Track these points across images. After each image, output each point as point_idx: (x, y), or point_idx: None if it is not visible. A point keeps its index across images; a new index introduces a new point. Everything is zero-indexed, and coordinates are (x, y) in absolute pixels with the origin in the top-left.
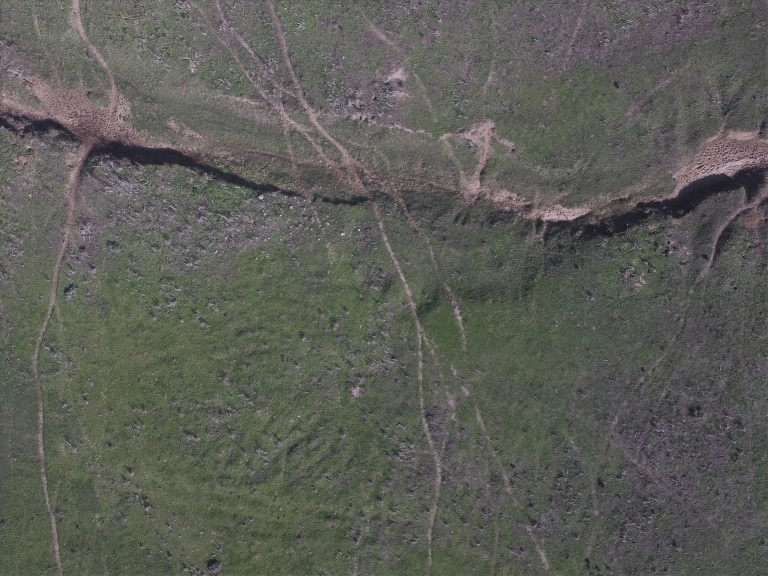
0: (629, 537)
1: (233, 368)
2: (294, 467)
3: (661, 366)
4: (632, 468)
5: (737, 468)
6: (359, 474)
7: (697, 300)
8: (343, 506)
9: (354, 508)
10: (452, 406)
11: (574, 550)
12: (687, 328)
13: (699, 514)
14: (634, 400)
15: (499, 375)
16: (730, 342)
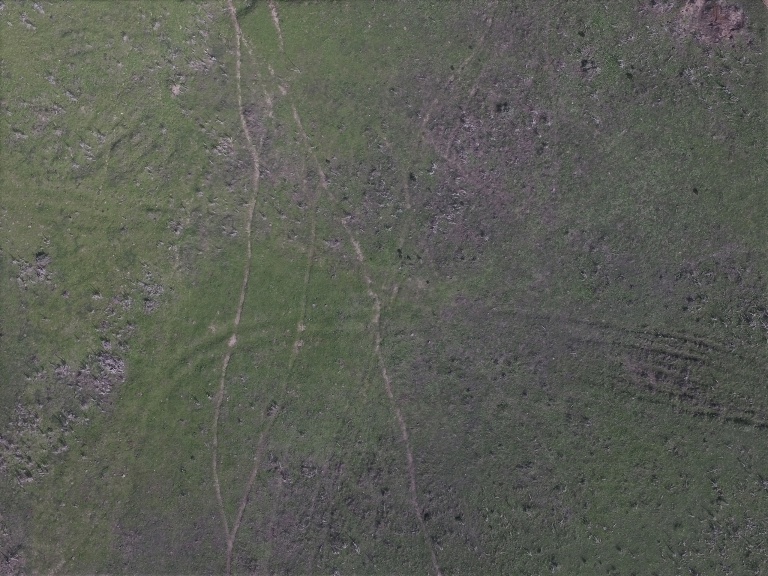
0: (439, 228)
1: (59, 68)
2: (117, 161)
3: (470, 65)
4: (442, 162)
5: (542, 161)
6: (179, 167)
7: (504, 1)
8: (164, 199)
9: (175, 200)
10: (270, 104)
11: (387, 241)
12: (495, 28)
13: (507, 206)
14: (444, 97)
15: (315, 75)
16: (536, 41)
